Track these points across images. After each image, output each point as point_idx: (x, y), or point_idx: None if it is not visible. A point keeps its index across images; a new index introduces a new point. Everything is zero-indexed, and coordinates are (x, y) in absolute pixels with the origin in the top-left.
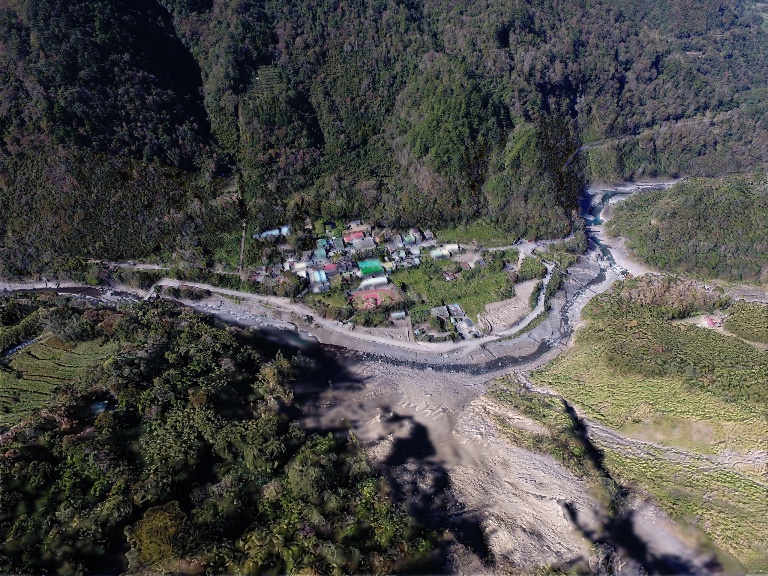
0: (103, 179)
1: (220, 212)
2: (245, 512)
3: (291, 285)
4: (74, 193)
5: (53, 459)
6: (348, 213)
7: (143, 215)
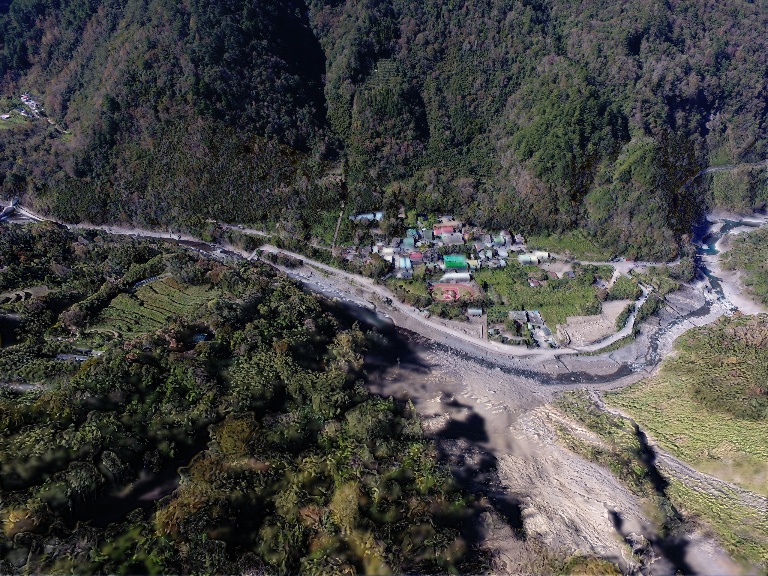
0: (229, 150)
1: (323, 191)
2: (306, 440)
3: (377, 267)
4: (204, 159)
5: (160, 369)
6: (442, 207)
7: (257, 186)
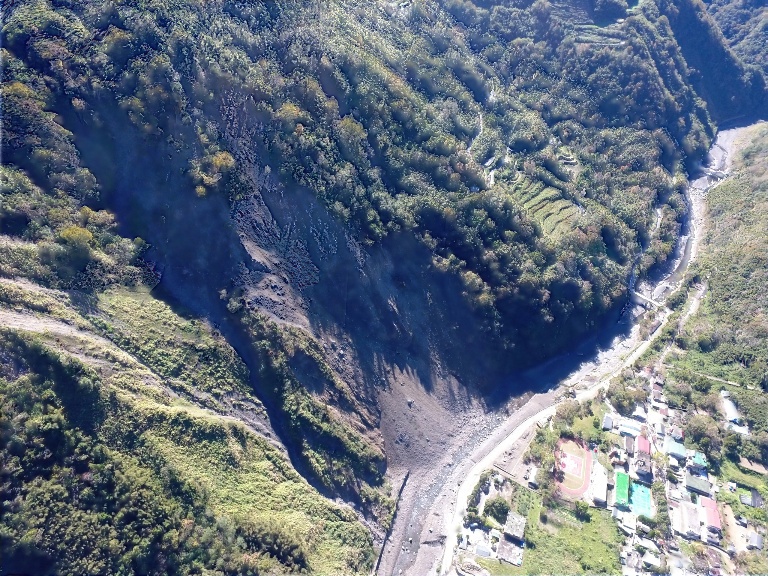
0: None
1: None
2: None
3: (617, 387)
4: None
5: None
6: None
7: None
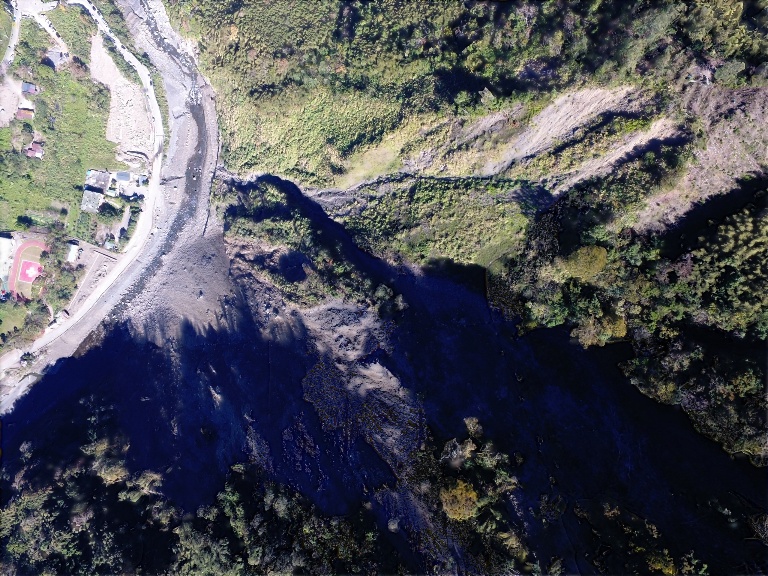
0: None
1: None
2: None
3: None
4: None
5: None
6: None
7: None
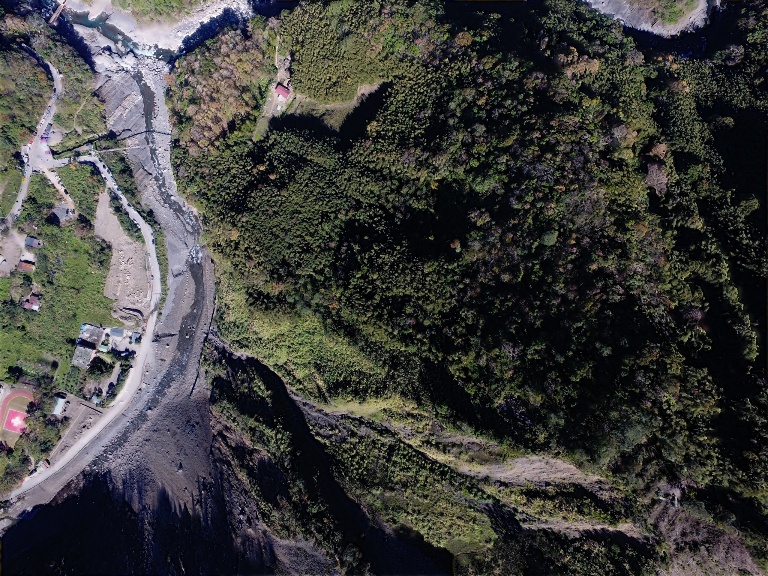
0: None
1: None
2: None
3: None
4: None
5: None
6: None
7: None
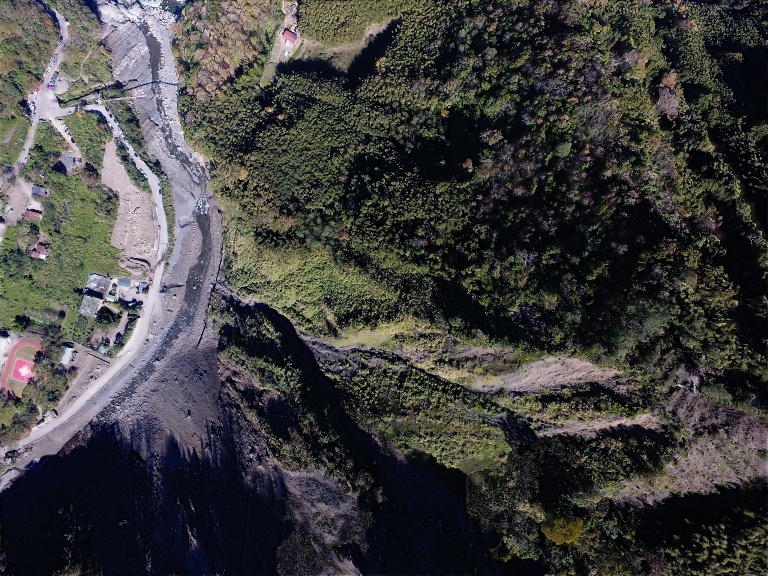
0: None
1: None
2: None
3: None
4: None
5: None
6: None
7: None
